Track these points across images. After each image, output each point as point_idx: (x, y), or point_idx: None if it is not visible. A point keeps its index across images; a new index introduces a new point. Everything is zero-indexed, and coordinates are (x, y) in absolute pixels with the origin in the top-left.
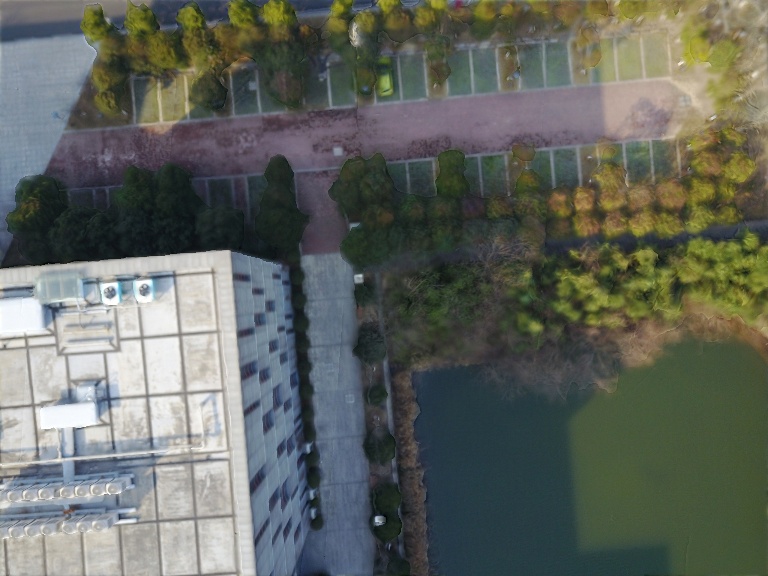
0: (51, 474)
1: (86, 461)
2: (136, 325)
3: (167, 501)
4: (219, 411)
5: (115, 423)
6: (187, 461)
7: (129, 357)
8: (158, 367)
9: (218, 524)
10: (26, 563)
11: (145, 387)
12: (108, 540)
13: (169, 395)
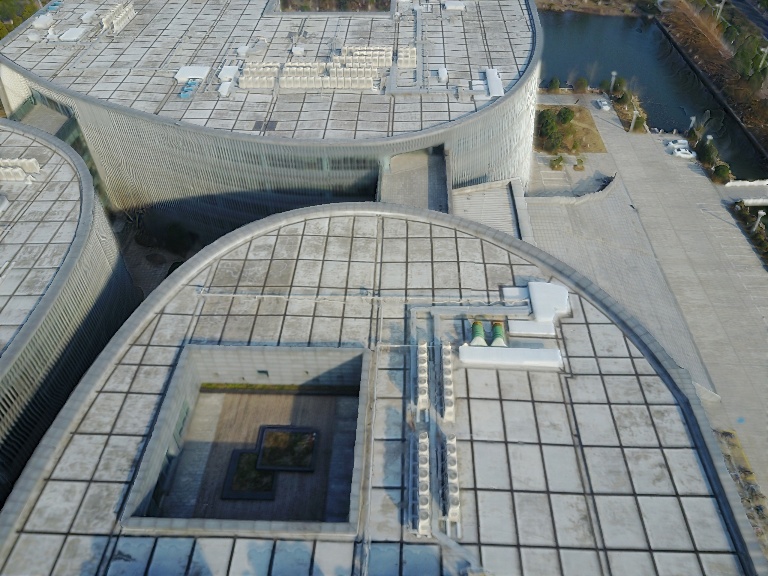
0: None
1: None
2: None
3: None
4: (113, 0)
5: (101, 14)
6: None
7: None
8: None
9: None
10: None
11: None
12: None
13: None
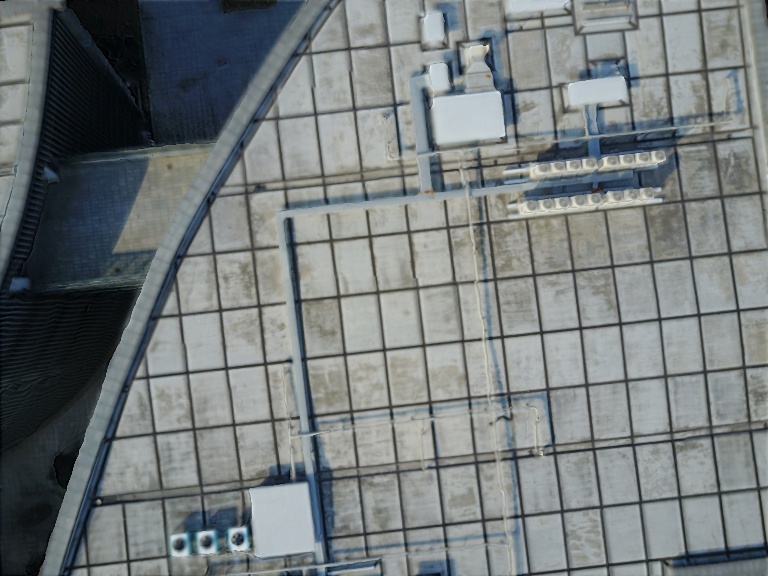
0: (570, 158)
1: (606, 143)
2: (655, 2)
3: (692, 180)
4: (741, 88)
5: (635, 103)
6: (708, 140)
7: (648, 35)
8: (678, 45)
9: (745, 202)
10: (550, 247)
11: (665, 65)
12: (633, 221)
13: (689, 73)
